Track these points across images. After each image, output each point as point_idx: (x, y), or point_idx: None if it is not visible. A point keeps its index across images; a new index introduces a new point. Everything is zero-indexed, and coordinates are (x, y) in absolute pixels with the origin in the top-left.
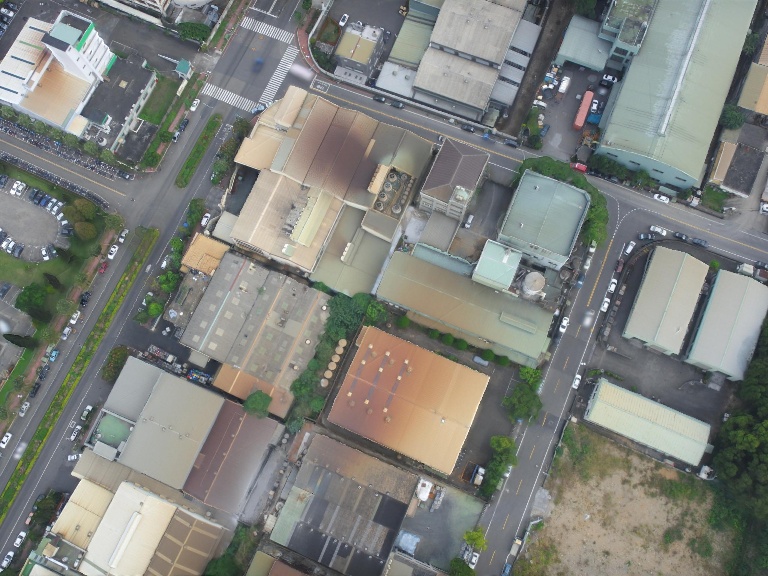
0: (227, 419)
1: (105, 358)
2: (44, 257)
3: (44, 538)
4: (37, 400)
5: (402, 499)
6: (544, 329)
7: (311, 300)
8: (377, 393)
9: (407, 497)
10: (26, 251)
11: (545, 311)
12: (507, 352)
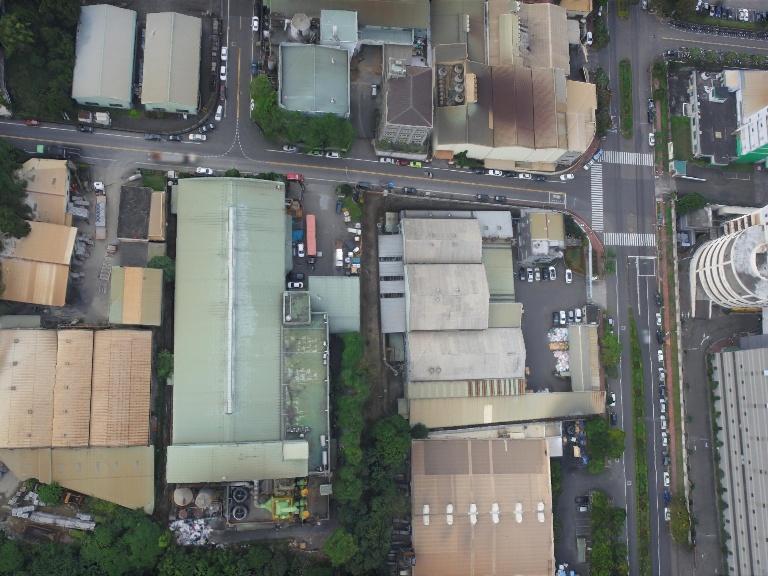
0: None
1: None
2: None
3: None
4: None
5: None
6: None
7: None
8: None
9: None
10: None
11: None
12: None
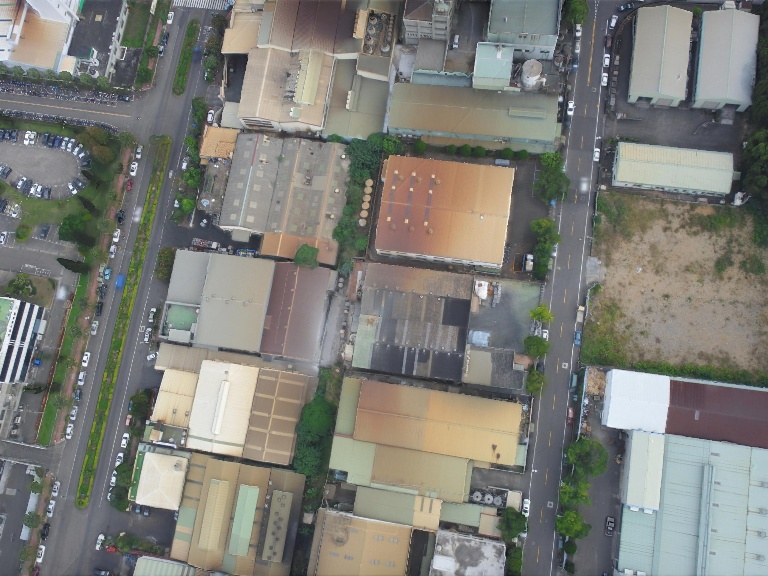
0: (282, 278)
1: (155, 264)
2: (72, 191)
3: (147, 426)
4: (104, 317)
5: (463, 296)
6: (553, 112)
7: (329, 153)
8: (414, 211)
9: (468, 294)
10: (54, 191)
11: (549, 96)
12: (524, 146)
